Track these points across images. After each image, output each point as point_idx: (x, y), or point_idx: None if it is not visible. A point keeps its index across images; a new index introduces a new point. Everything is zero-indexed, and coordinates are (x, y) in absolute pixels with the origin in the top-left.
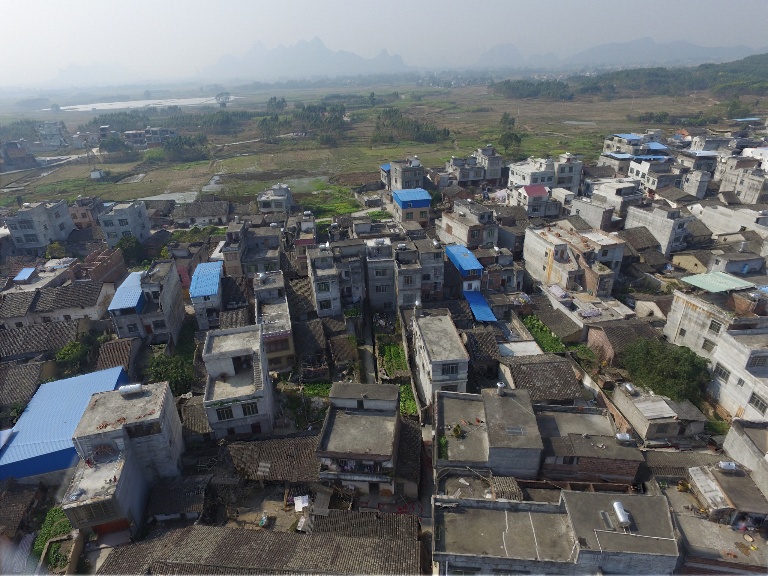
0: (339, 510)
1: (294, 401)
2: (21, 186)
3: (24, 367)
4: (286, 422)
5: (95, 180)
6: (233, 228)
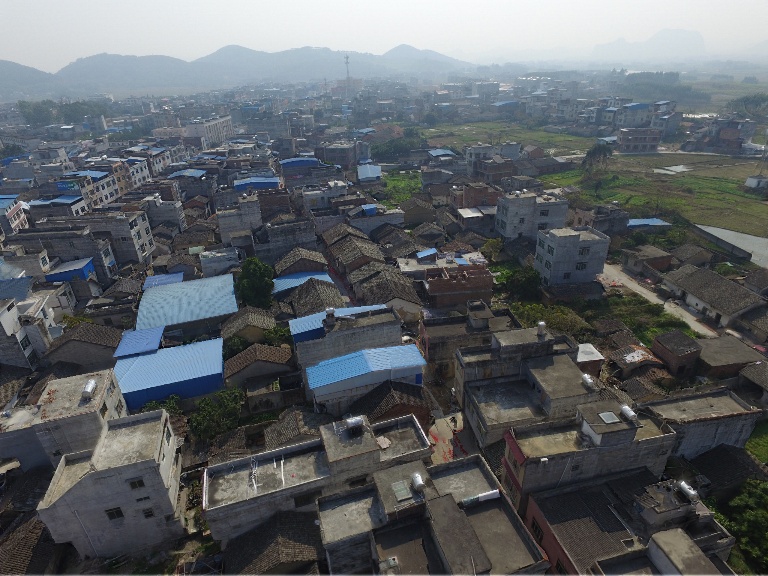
0: None
1: (142, 575)
2: (676, 171)
3: (247, 318)
4: (86, 573)
5: (744, 189)
6: (514, 336)
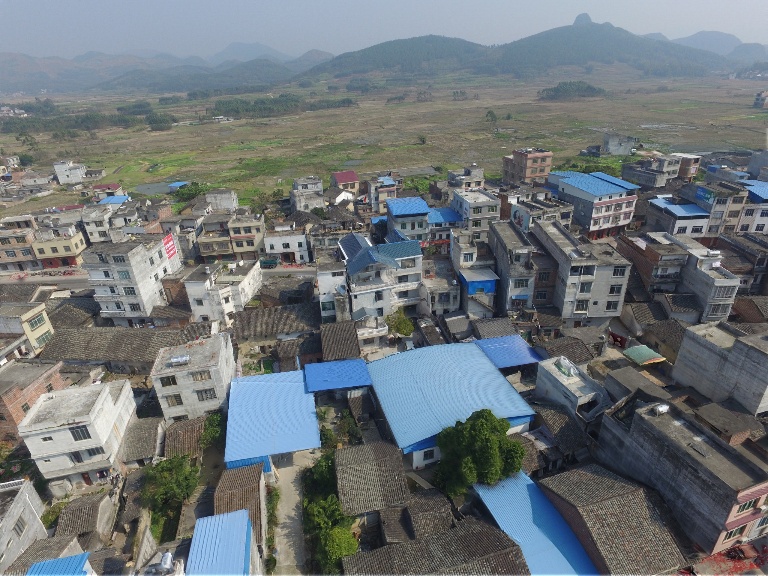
0: (72, 371)
1: (43, 482)
2: None
3: None
4: None
5: None
6: None
